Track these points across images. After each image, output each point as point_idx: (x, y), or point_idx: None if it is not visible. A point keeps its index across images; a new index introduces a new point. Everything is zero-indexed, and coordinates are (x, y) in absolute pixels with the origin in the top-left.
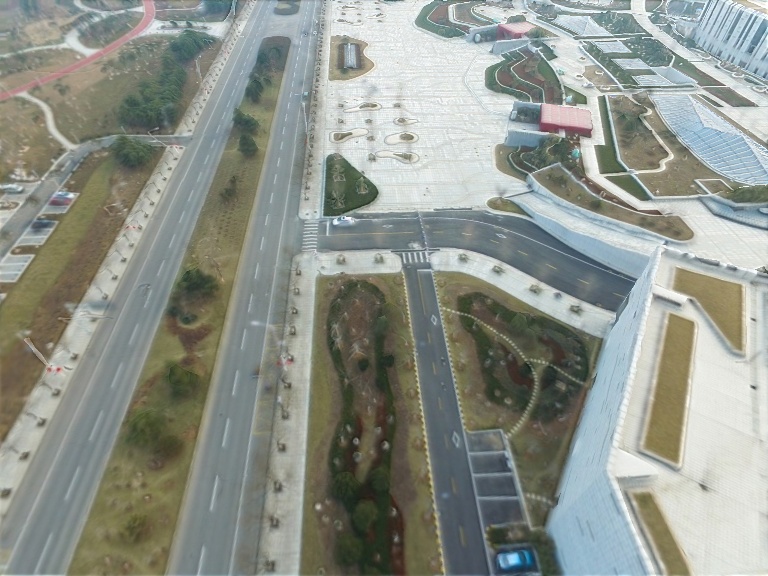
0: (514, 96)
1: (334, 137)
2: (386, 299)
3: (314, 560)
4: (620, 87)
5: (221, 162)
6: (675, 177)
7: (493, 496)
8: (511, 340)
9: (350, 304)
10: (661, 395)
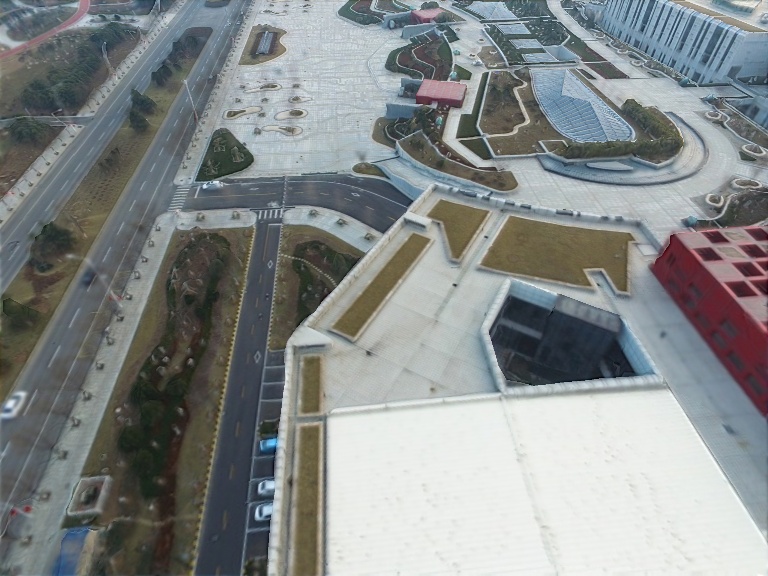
0: (409, 75)
1: (227, 114)
2: (231, 248)
3: (102, 450)
4: (506, 64)
5: (114, 138)
6: (522, 139)
7: (275, 399)
8: (332, 278)
9: (195, 252)
10: (369, 291)
